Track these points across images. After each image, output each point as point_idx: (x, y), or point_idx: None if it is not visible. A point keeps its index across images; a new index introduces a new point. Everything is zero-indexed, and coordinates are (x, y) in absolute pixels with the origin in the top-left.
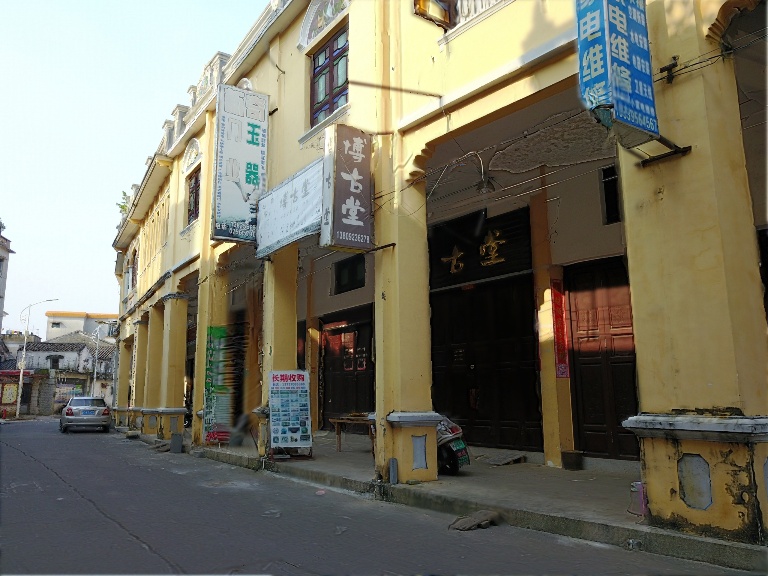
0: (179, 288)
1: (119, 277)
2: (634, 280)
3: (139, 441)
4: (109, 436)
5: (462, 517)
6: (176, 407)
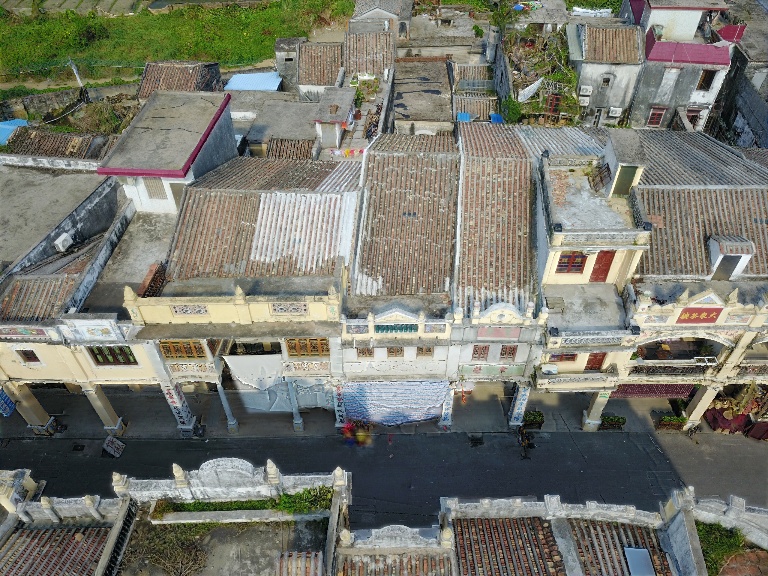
0: None
1: None
2: (20, 412)
3: None
4: None
5: (2, 443)
6: None
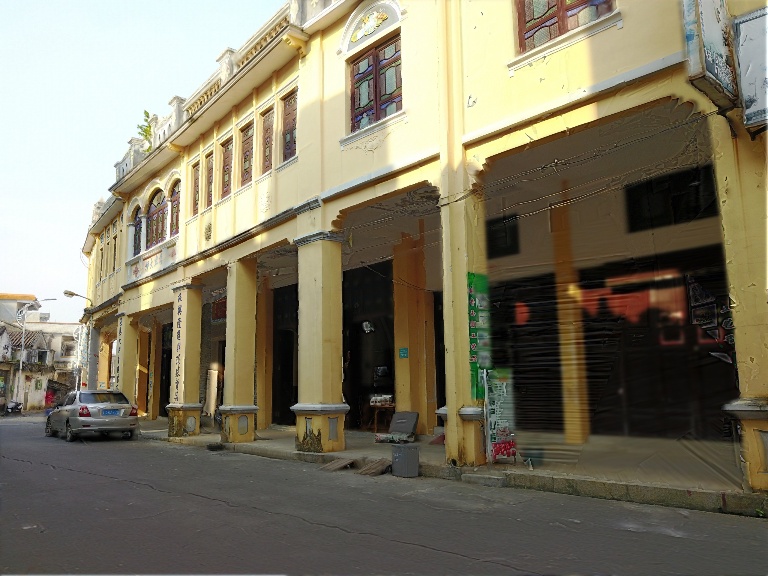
0: (334, 224)
1: (94, 237)
2: None
3: (242, 454)
4: (156, 445)
5: None
6: (335, 403)
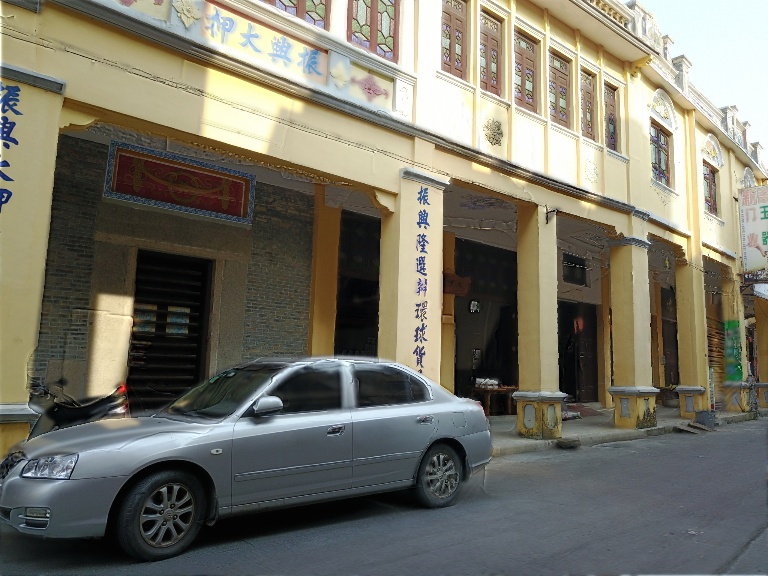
0: None
1: None
2: None
3: (606, 443)
4: None
5: None
6: None
